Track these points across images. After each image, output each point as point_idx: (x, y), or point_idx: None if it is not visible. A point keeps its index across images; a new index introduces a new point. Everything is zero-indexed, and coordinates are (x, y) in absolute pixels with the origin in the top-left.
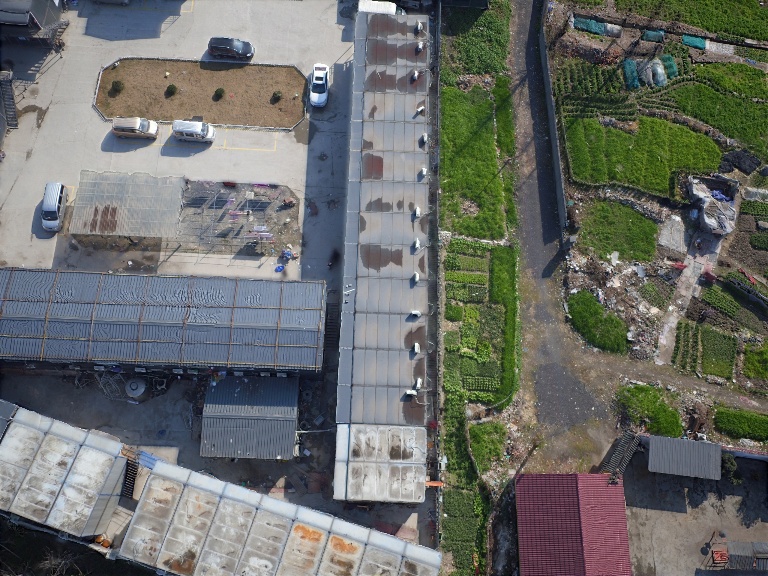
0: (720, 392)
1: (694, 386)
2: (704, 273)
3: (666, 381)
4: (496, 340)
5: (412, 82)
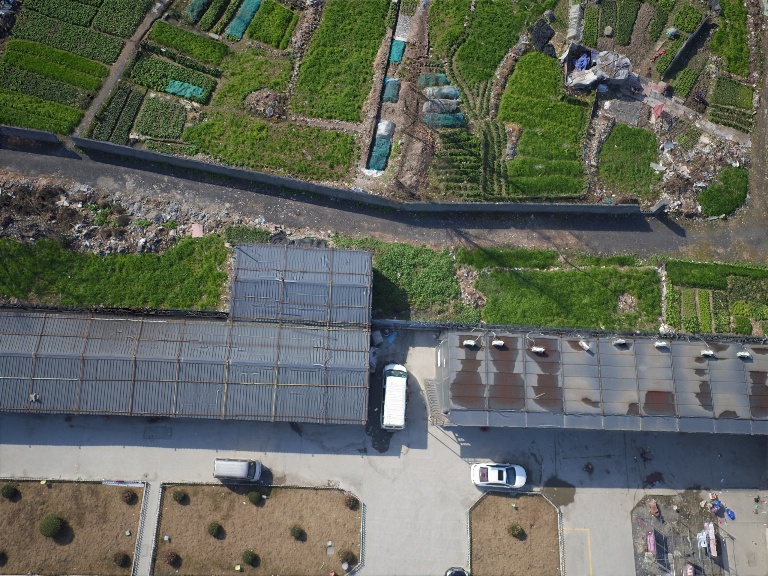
0: (766, 99)
1: (765, 119)
2: (660, 91)
3: (765, 141)
4: (763, 286)
5: (546, 355)
